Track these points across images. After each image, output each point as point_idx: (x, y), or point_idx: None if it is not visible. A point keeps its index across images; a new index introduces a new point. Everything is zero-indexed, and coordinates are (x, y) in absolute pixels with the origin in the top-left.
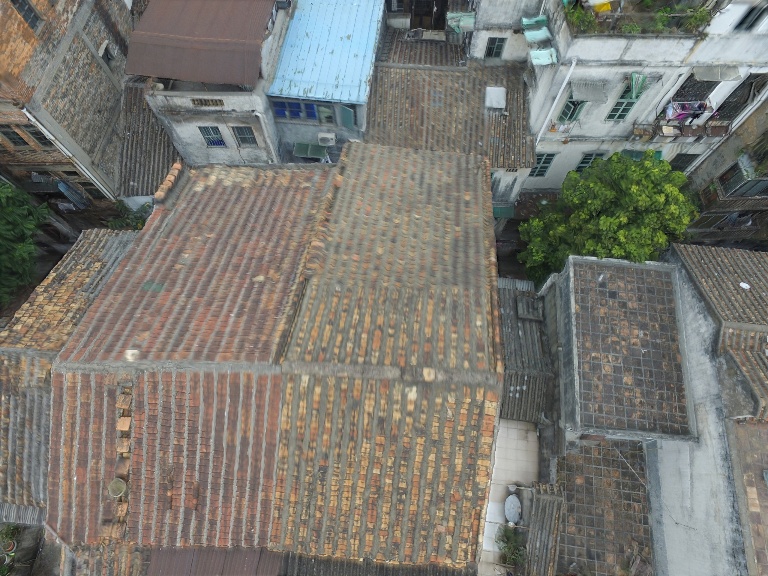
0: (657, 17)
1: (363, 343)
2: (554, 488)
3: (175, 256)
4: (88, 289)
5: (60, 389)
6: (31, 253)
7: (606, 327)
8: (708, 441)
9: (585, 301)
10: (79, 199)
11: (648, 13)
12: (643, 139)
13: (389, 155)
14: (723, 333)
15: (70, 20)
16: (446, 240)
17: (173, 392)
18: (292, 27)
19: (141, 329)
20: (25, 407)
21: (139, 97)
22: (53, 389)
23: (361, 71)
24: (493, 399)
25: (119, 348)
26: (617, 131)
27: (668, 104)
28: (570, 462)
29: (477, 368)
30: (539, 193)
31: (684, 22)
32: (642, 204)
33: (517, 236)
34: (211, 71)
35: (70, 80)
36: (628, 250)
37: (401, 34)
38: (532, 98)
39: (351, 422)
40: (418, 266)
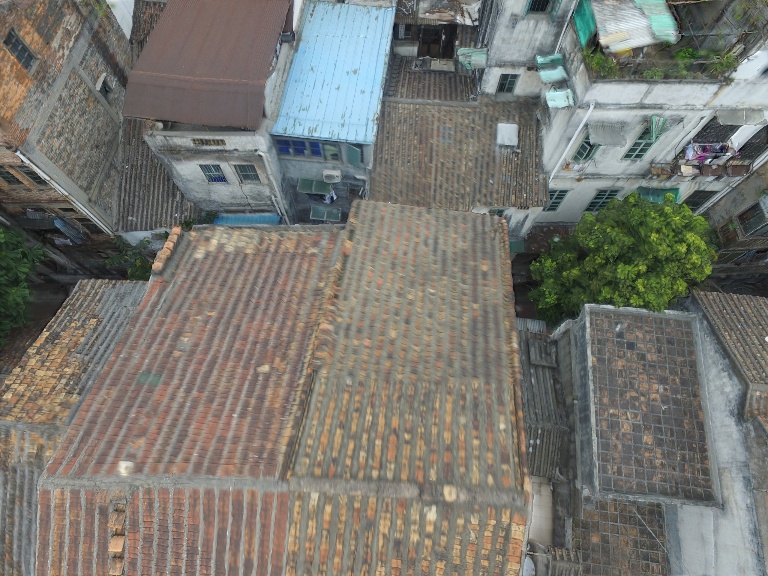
0: (679, 58)
1: (377, 451)
2: (570, 553)
3: (174, 340)
4: (83, 350)
5: (47, 506)
6: (28, 281)
7: (624, 381)
8: (734, 510)
9: (602, 353)
10: (76, 234)
11: (669, 53)
12: (661, 178)
13: (400, 215)
14: (750, 396)
15: (66, 56)
16: (464, 321)
17: (170, 510)
18: (296, 61)
19: (136, 434)
20: (15, 483)
21: (138, 129)
22: (40, 507)
23: (368, 108)
24: (520, 522)
25: (112, 458)
26: (633, 169)
27: (688, 145)
28: (585, 518)
29: (502, 485)
30: (550, 226)
31: (709, 66)
32: (663, 254)
33: (527, 268)
34: (212, 113)
35: (66, 118)
36: (647, 300)
37: (408, 63)
38: (545, 135)
39: (365, 543)
40: (435, 354)
